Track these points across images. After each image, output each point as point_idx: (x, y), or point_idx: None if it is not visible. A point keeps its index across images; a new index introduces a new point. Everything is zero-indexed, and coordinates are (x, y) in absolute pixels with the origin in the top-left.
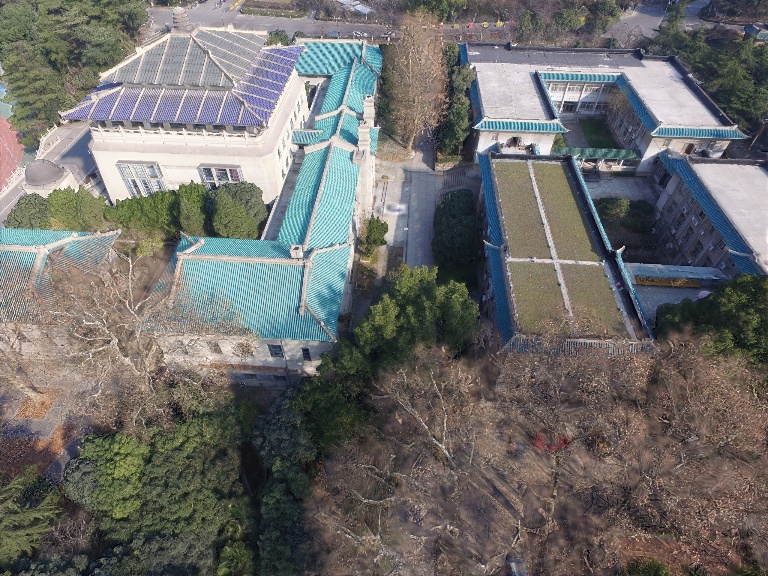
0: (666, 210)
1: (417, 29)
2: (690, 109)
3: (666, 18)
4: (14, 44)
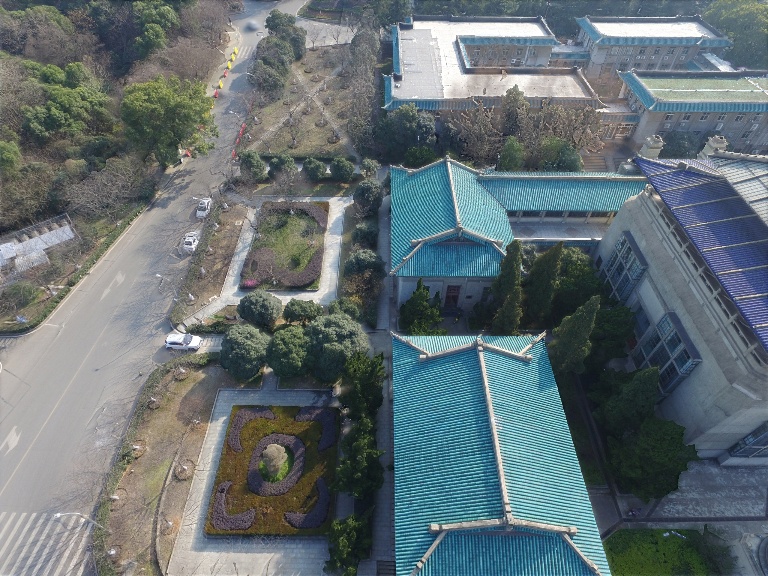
0: (603, 73)
1: None
2: (509, 27)
3: None
4: None
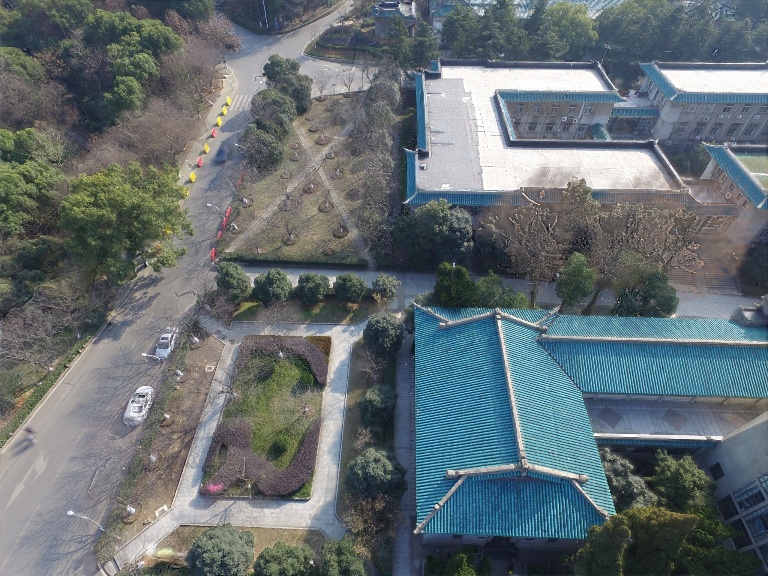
0: (674, 134)
1: (239, 270)
2: (559, 76)
3: (387, 35)
4: None
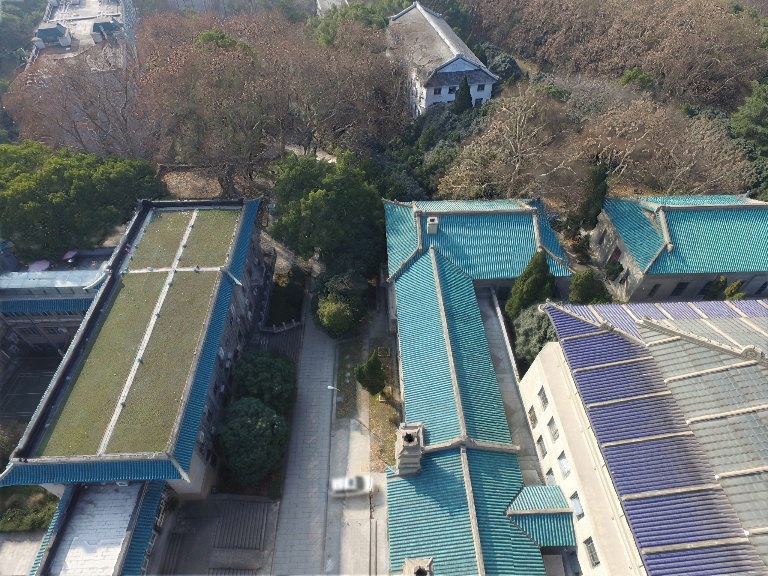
0: None
1: None
2: None
3: None
4: None
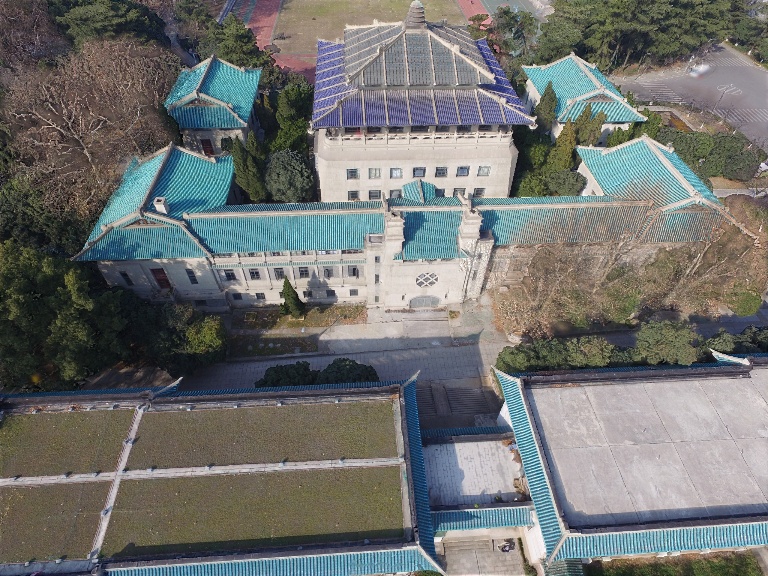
0: None
1: None
2: None
3: None
4: (498, 7)
